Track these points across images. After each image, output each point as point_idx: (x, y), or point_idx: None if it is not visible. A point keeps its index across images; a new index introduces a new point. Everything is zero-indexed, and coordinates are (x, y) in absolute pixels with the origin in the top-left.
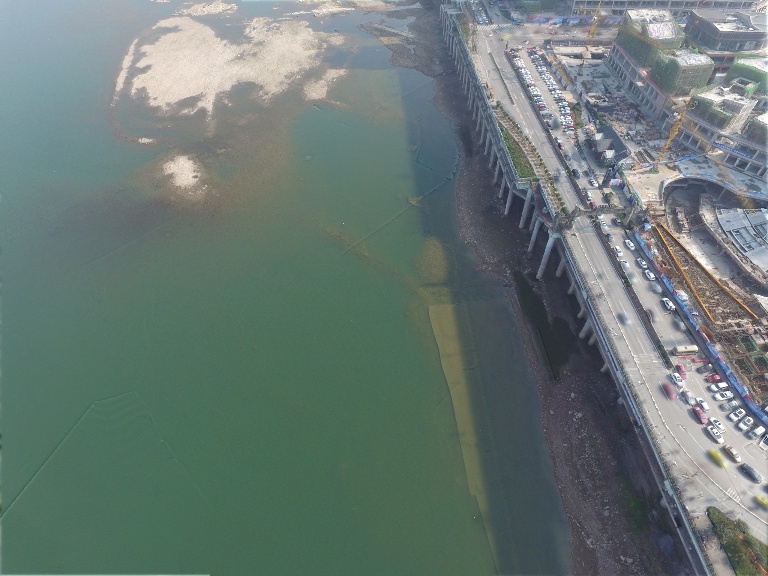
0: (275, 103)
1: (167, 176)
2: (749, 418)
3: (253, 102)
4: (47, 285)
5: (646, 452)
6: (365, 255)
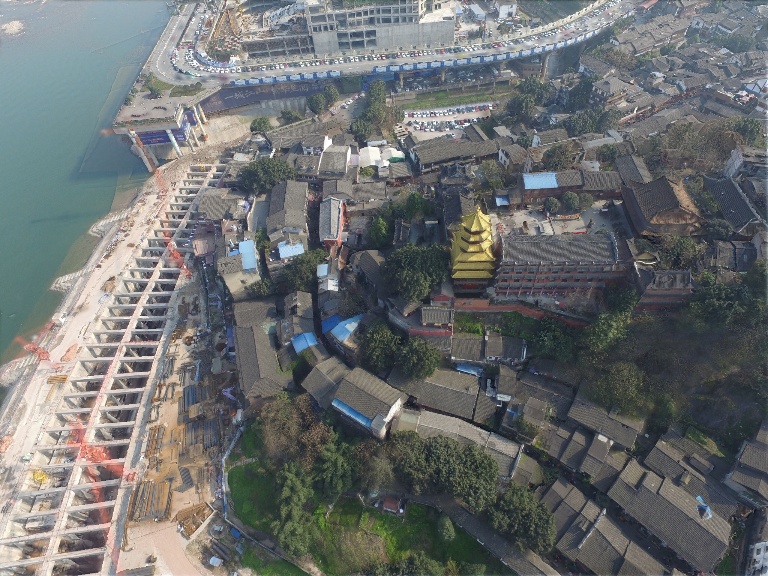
0: None
1: (3, 30)
2: (191, 56)
3: None
4: None
5: None
6: (100, 53)
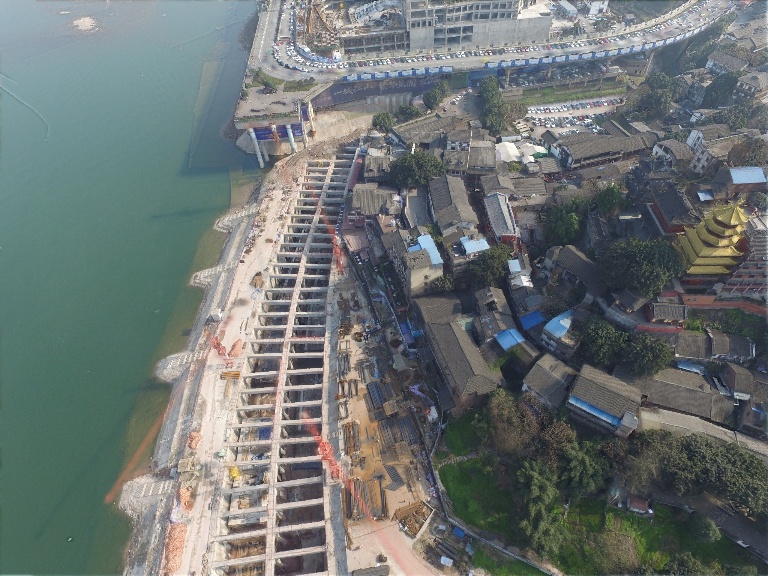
0: None
1: (75, 26)
2: (293, 51)
3: None
4: None
5: None
6: (179, 49)
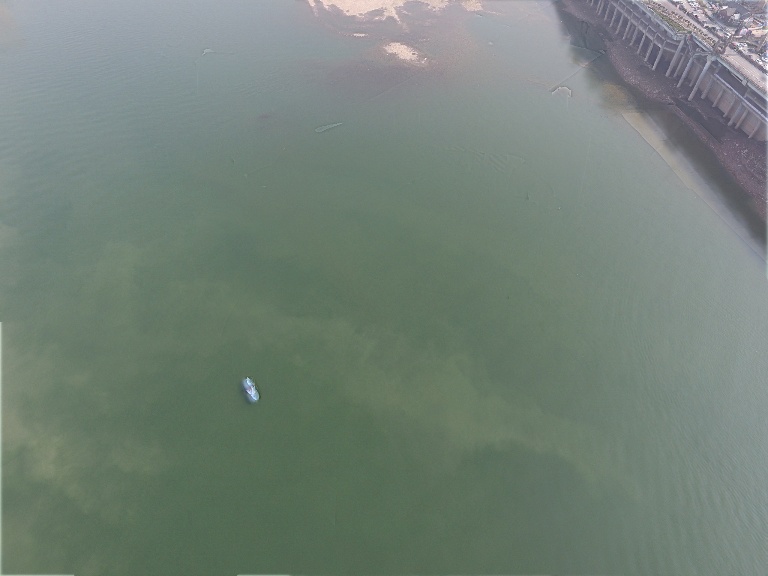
0: (445, 13)
1: (392, 54)
2: None
3: (427, 12)
4: (342, 113)
5: None
6: None
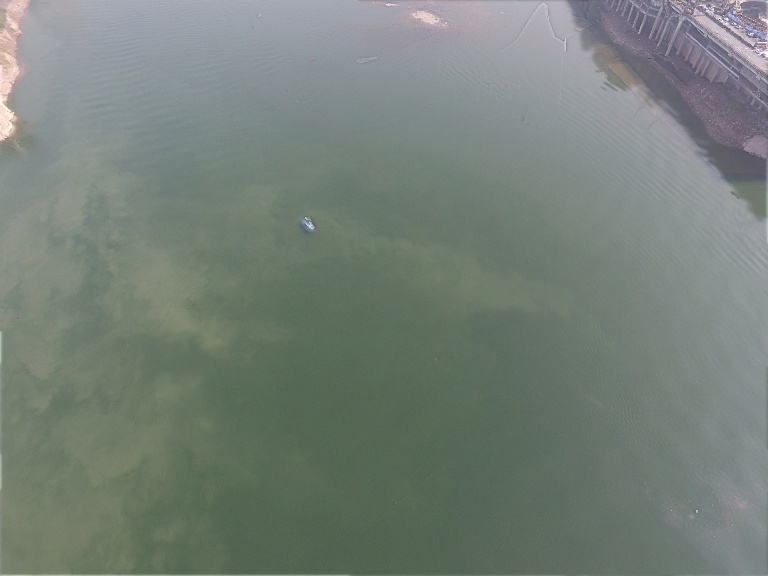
0: None
1: (418, 19)
2: None
3: None
4: (375, 61)
5: (743, 84)
6: None
